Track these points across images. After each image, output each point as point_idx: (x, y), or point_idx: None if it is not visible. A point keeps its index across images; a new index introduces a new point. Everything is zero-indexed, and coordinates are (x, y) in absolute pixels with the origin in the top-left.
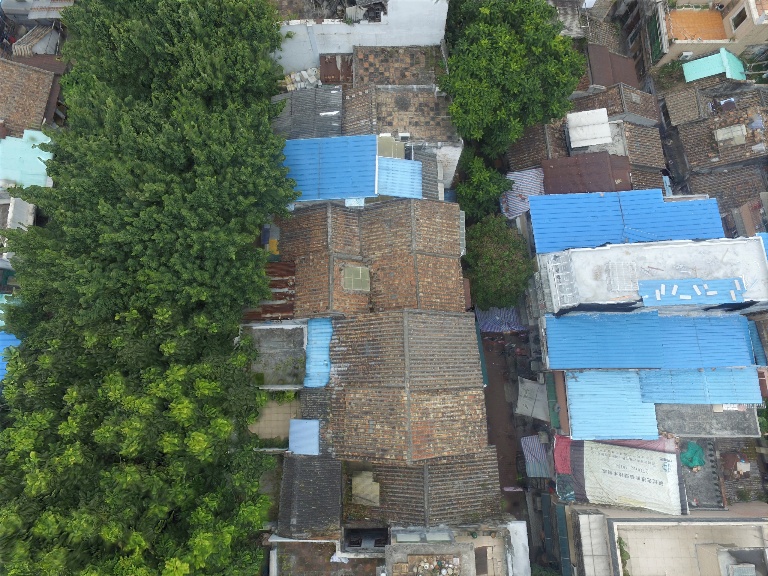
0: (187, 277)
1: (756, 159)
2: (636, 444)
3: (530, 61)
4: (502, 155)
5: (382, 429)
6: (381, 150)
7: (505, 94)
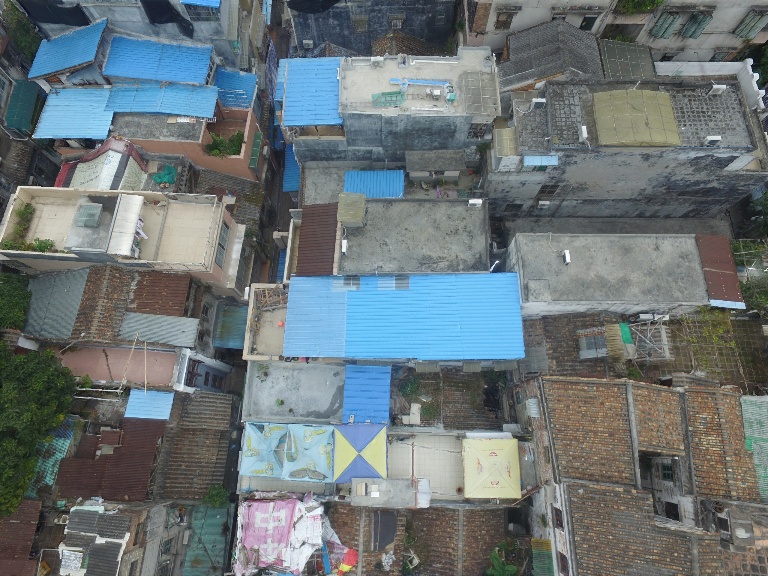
0: None
1: None
2: (100, 152)
3: None
4: None
5: None
6: None
7: None
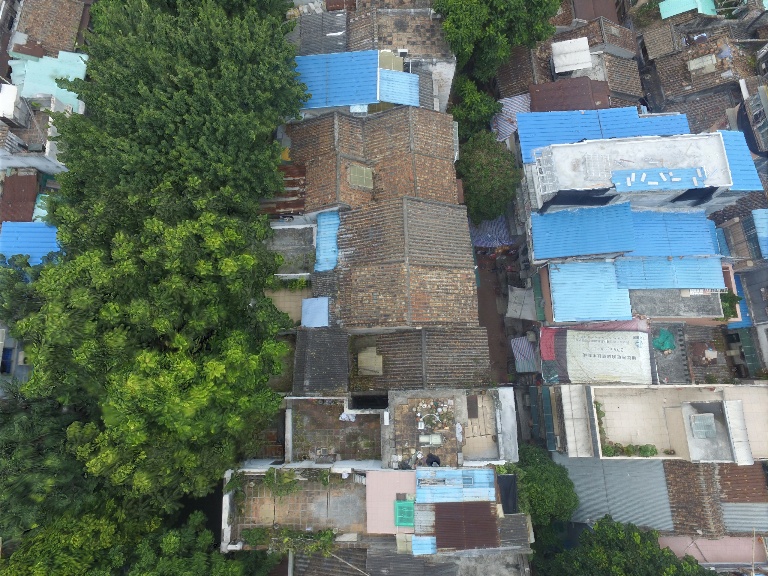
0: (213, 156)
1: (725, 85)
2: (613, 327)
3: None
4: (493, 87)
5: (385, 298)
6: (382, 63)
7: (493, 12)
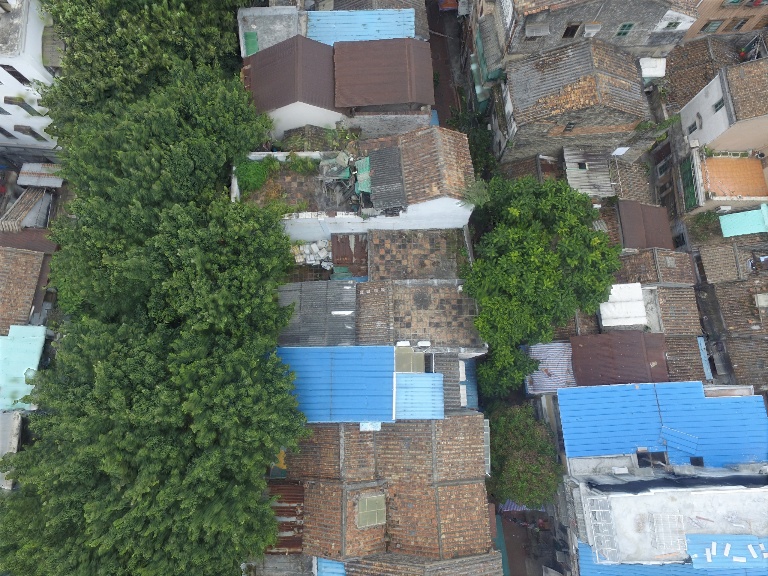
0: (184, 567)
1: None
2: None
3: (564, 271)
4: None
5: None
6: (399, 364)
7: (536, 305)
